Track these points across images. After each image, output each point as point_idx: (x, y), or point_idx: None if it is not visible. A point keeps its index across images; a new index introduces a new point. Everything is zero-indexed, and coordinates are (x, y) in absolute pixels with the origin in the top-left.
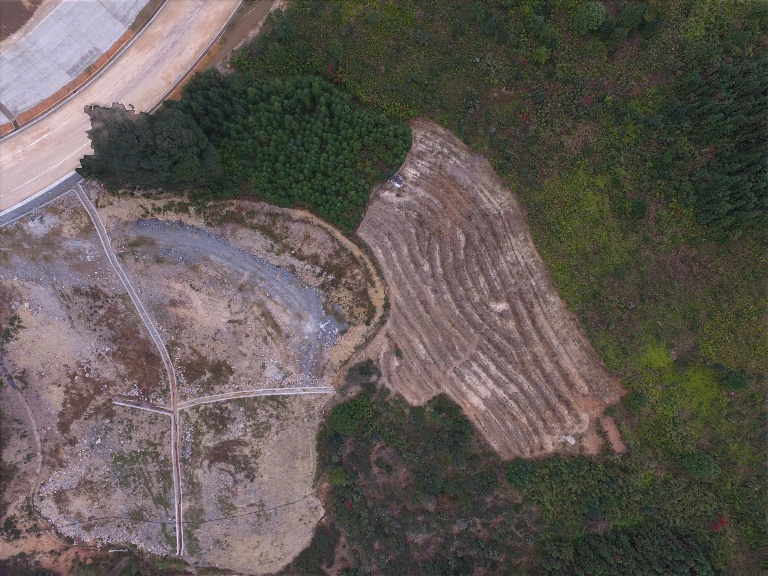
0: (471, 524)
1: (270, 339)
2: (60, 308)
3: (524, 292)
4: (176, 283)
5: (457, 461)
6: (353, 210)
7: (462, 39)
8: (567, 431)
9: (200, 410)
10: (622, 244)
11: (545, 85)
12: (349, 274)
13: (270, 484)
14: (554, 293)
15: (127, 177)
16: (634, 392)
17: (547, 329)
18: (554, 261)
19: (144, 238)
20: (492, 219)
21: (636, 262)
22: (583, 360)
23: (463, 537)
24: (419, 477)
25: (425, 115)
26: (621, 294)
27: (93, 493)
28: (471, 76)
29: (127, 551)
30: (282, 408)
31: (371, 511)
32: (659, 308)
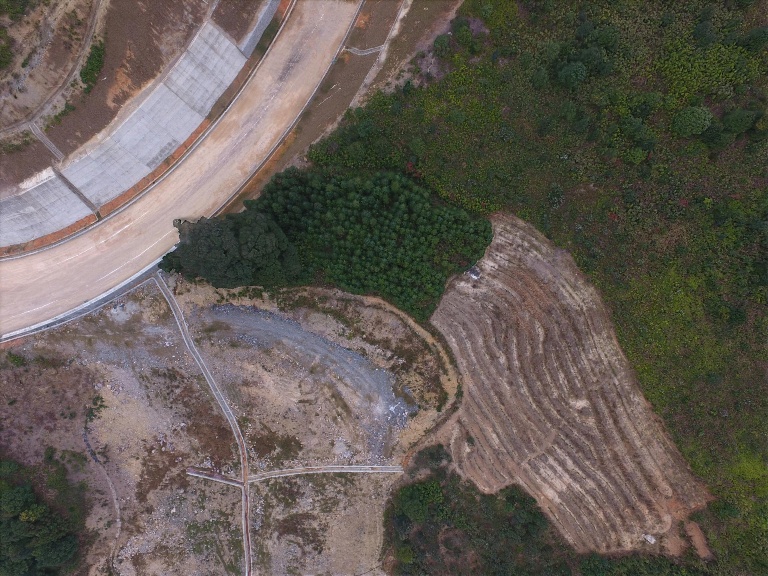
0: None
1: (340, 419)
2: (139, 388)
3: (606, 391)
4: (249, 365)
5: (529, 551)
6: (428, 300)
7: (549, 135)
8: (647, 530)
9: (270, 484)
10: (716, 349)
11: (638, 184)
12: (421, 359)
13: (337, 556)
14: (638, 393)
15: None
16: (724, 501)
17: (630, 430)
18: (640, 361)
19: (219, 323)
20: (574, 315)
21: (731, 368)
22: (668, 463)
23: None
24: (489, 562)
25: (506, 209)
26: (713, 400)
27: (168, 558)
28: (557, 172)
29: None
30: (350, 485)
31: None
32: (755, 417)
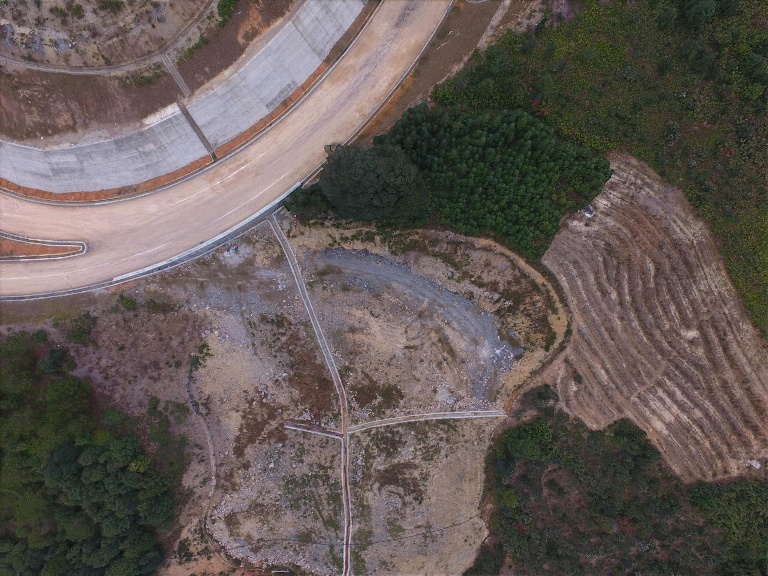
0: (653, 546)
1: (446, 364)
2: (245, 336)
3: (717, 320)
4: (357, 310)
5: (638, 484)
6: (541, 239)
7: (669, 75)
8: (752, 455)
9: (372, 434)
10: None
11: (751, 120)
12: (528, 301)
13: (437, 506)
14: (746, 321)
15: (350, 212)
16: None
17: (740, 356)
18: (749, 290)
19: (332, 267)
20: (685, 249)
21: None
22: None
23: (642, 559)
24: (595, 500)
25: (622, 147)
26: None
27: (263, 516)
28: (674, 110)
29: (288, 572)
30: (453, 431)
31: (542, 533)
32: None
